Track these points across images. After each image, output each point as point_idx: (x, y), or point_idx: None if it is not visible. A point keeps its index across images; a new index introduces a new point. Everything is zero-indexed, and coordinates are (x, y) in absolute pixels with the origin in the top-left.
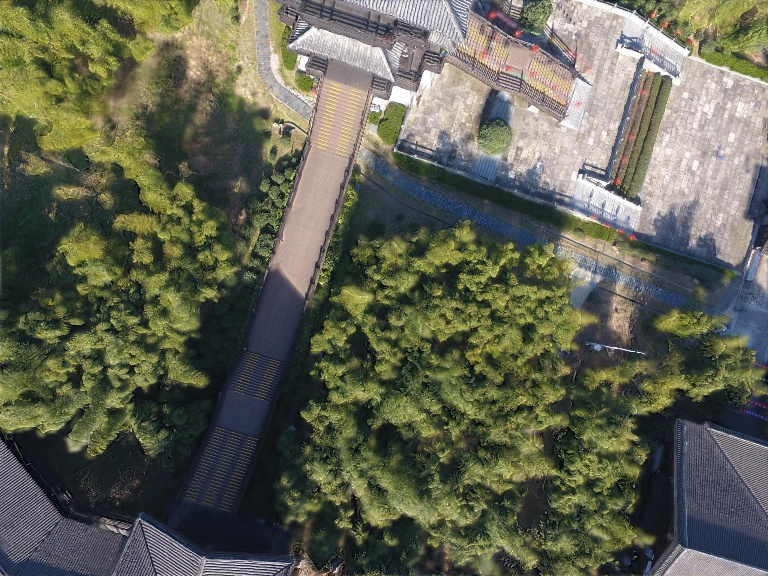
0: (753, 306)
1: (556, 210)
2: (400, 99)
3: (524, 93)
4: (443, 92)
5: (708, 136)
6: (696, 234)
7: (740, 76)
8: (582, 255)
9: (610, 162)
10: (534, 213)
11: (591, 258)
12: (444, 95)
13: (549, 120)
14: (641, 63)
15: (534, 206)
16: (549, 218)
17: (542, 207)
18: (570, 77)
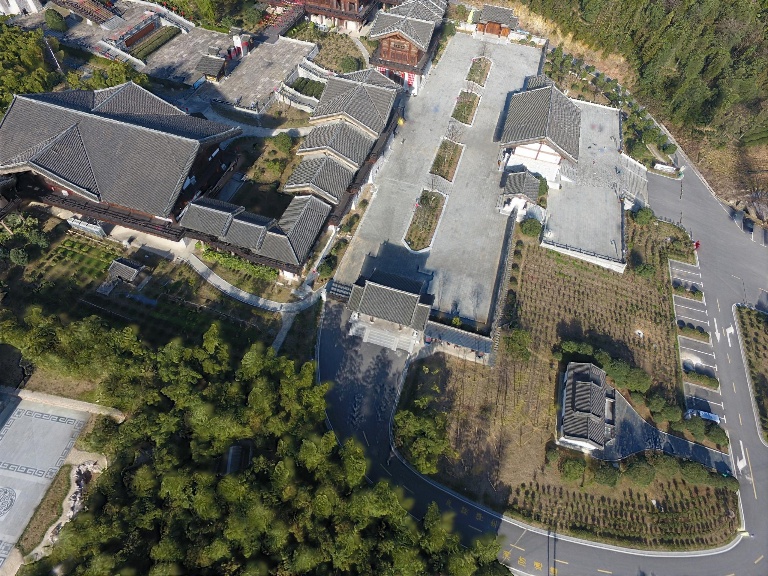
0: (198, 100)
1: (84, 52)
2: (17, 12)
3: (75, 8)
4: (43, 14)
5: (197, 48)
6: (175, 75)
7: (222, 34)
8: None
9: (122, 39)
10: (70, 52)
11: None
12: (43, 15)
13: (97, 27)
14: None
15: (71, 49)
16: (78, 54)
17: (76, 50)
18: (111, 14)
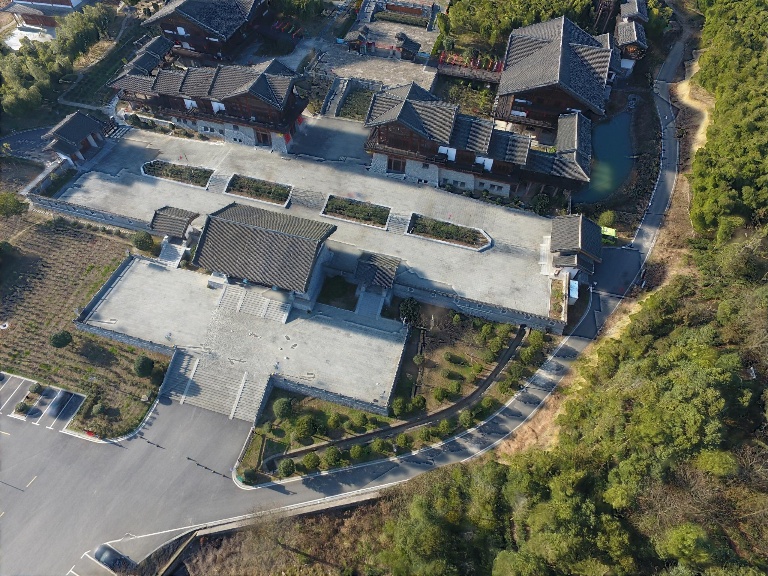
0: (325, 46)
1: None
2: None
3: None
4: None
5: None
6: None
7: None
8: (350, 3)
9: None
10: None
11: (348, 5)
12: None
13: None
14: (428, 7)
15: None
16: None
17: None
18: None
